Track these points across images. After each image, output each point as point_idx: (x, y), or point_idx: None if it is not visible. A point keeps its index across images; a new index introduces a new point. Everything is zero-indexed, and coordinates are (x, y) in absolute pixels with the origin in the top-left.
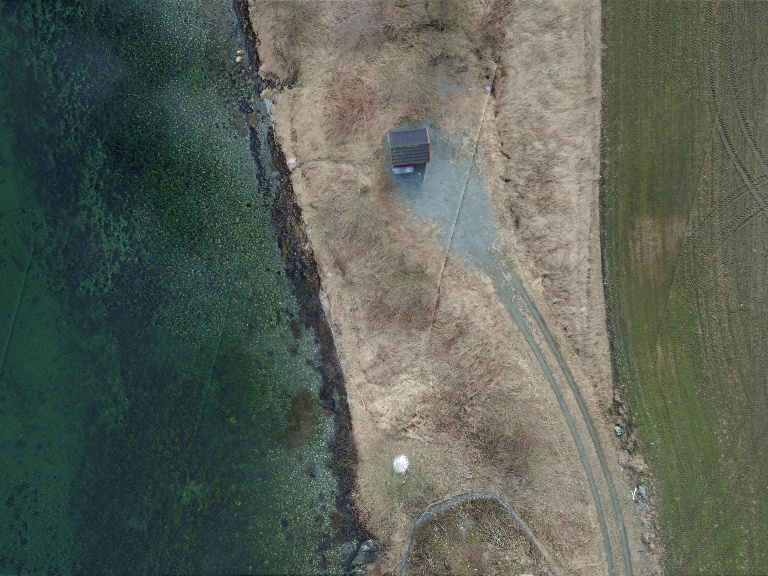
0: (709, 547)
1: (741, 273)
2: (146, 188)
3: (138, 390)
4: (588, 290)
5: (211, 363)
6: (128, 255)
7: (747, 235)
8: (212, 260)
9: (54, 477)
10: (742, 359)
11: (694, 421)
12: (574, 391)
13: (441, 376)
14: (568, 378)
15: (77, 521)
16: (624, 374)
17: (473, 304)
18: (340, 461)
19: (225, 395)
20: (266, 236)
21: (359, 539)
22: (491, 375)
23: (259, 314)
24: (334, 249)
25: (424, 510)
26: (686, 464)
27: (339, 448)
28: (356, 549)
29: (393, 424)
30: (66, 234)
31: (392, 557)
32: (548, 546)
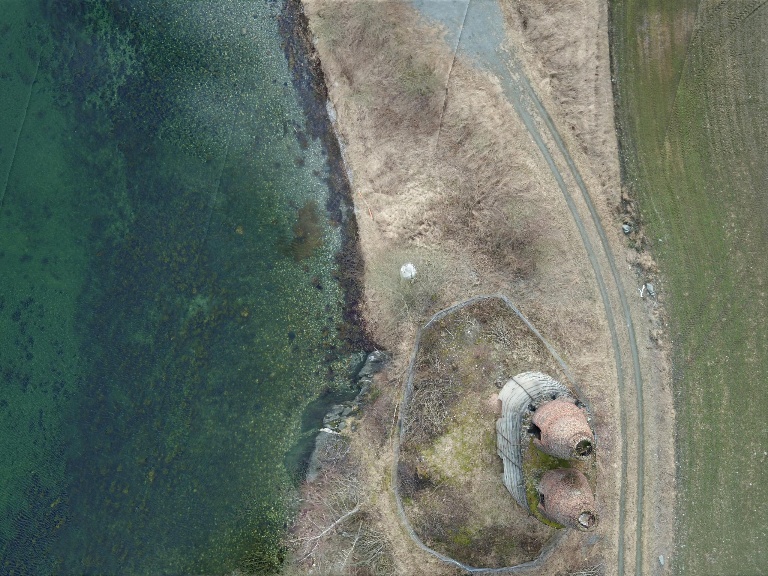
0: (717, 341)
1: (750, 64)
2: (152, 1)
3: (144, 204)
4: (596, 87)
5: (218, 176)
6: (134, 68)
7: (756, 25)
8: (219, 72)
9: (60, 292)
10: (750, 151)
11: (702, 215)
12: (582, 190)
13: (448, 181)
14: (576, 177)
15: (83, 336)
16: (632, 171)
17: (481, 104)
18: (347, 272)
19: (232, 208)
20: (273, 47)
21: (366, 350)
22: (499, 176)
23: (266, 126)
24: (341, 57)
25: (431, 318)
26: (694, 259)
27: (346, 259)
28: (363, 361)
29: (400, 232)
30: (72, 48)
31: (399, 365)
32: (556, 345)
